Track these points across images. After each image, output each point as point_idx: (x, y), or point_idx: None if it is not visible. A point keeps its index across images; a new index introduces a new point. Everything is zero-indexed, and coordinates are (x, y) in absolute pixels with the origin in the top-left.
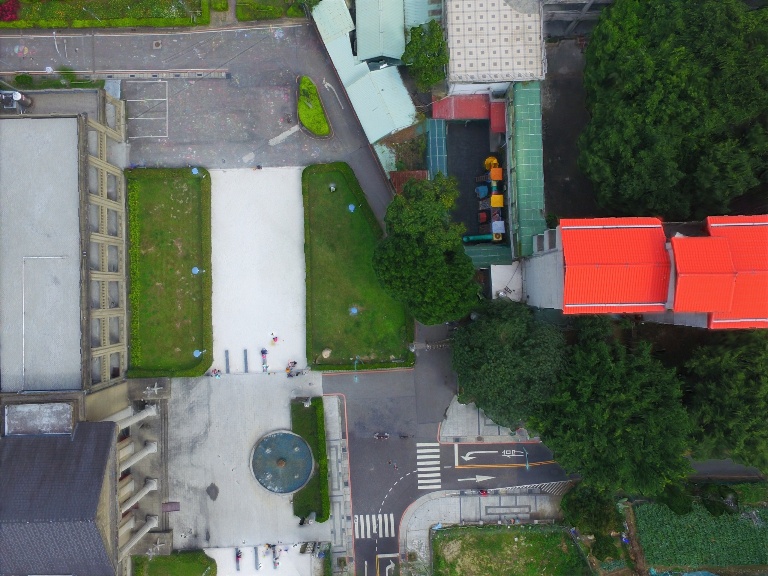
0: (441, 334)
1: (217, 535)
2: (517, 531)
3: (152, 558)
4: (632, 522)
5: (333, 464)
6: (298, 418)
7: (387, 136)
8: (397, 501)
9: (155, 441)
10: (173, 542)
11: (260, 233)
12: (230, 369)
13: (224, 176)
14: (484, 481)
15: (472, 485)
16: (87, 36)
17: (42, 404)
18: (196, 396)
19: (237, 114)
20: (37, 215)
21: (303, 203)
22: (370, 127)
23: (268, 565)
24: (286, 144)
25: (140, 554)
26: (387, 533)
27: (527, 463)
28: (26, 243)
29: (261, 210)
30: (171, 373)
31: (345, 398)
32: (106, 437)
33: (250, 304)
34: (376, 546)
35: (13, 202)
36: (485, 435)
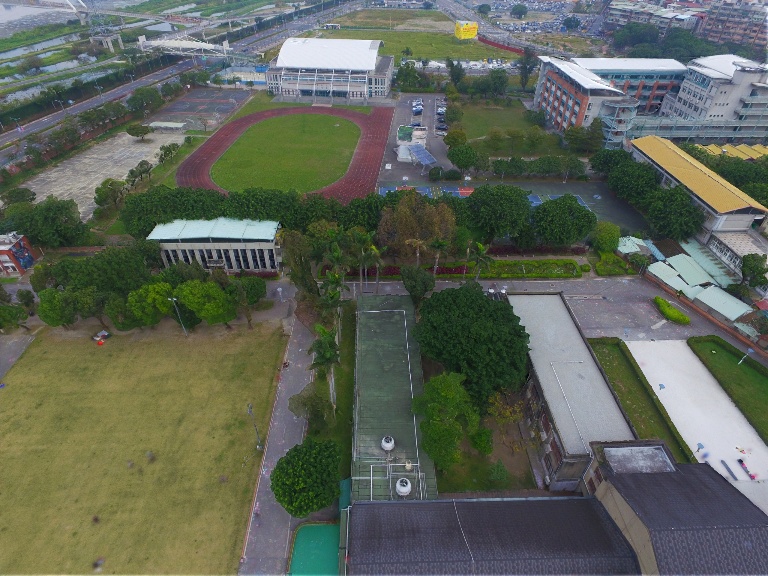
0: None
1: None
2: None
3: None
4: None
5: None
6: None
7: (741, 317)
8: None
9: None
10: None
11: (677, 377)
12: None
13: (630, 345)
14: None
15: None
16: (508, 282)
17: (633, 448)
18: None
19: (621, 314)
20: (550, 340)
21: (701, 357)
22: (727, 312)
23: None
24: (663, 328)
25: None
26: None
27: None
28: (549, 355)
29: (669, 364)
30: None
31: None
32: (712, 472)
33: (701, 425)
34: None
35: (530, 333)
36: None
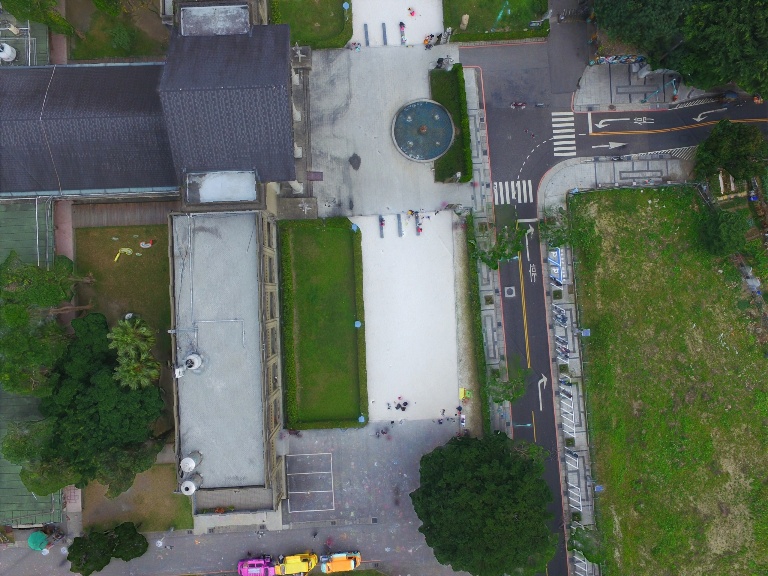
0: (572, 8)
1: (360, 204)
2: (651, 193)
3: (299, 223)
4: (758, 185)
5: (472, 133)
6: (439, 85)
7: None
8: (534, 168)
9: (299, 110)
10: (317, 211)
11: None
12: (369, 42)
13: None
14: (617, 148)
15: (606, 152)
16: None
17: (217, 8)
18: (336, 69)
19: None
20: None
21: None
22: None
23: (411, 233)
24: None
25: (287, 219)
26: (526, 199)
27: (675, 89)
28: None
29: None
30: (313, 42)
31: (481, 70)
32: (284, 34)
33: None
34: (515, 211)
35: None
36: (617, 103)
